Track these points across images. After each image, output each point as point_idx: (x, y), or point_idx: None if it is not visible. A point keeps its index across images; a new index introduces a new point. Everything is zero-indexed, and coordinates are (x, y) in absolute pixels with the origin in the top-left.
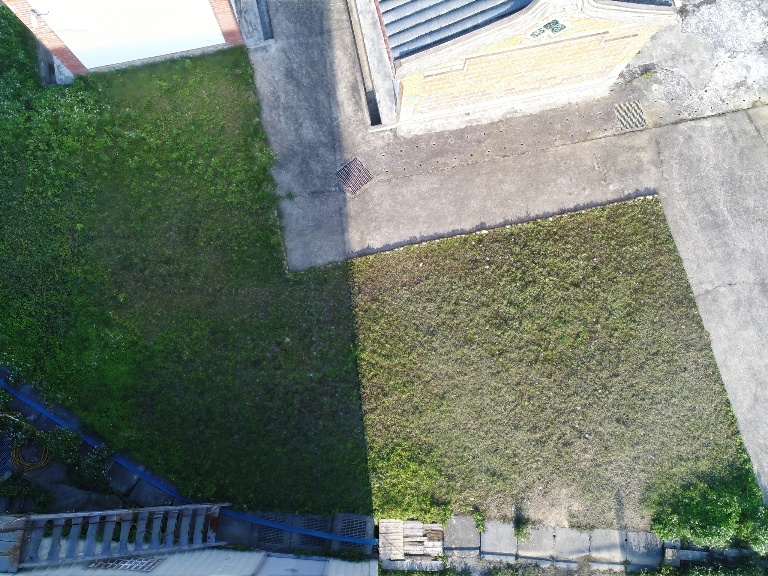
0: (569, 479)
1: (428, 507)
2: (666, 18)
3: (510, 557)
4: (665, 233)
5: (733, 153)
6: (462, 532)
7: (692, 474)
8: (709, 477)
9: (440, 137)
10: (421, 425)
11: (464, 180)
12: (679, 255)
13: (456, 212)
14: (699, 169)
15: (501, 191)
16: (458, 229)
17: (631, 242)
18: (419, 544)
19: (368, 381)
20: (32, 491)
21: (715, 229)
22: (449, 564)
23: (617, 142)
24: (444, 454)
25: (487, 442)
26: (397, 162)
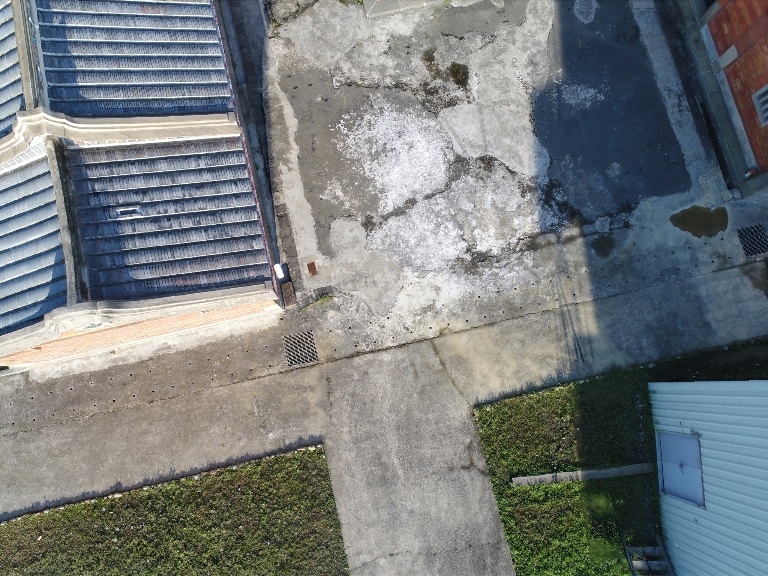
0: None
1: None
2: (258, 296)
3: None
4: (326, 491)
5: (413, 391)
6: None
7: None
8: None
9: (79, 380)
10: None
11: (102, 432)
12: (338, 519)
13: (89, 471)
14: (373, 412)
15: (143, 444)
16: (89, 492)
17: (285, 504)
18: None
19: None
20: None
21: (382, 485)
22: None
23: (282, 381)
24: None
25: None
26: (26, 412)
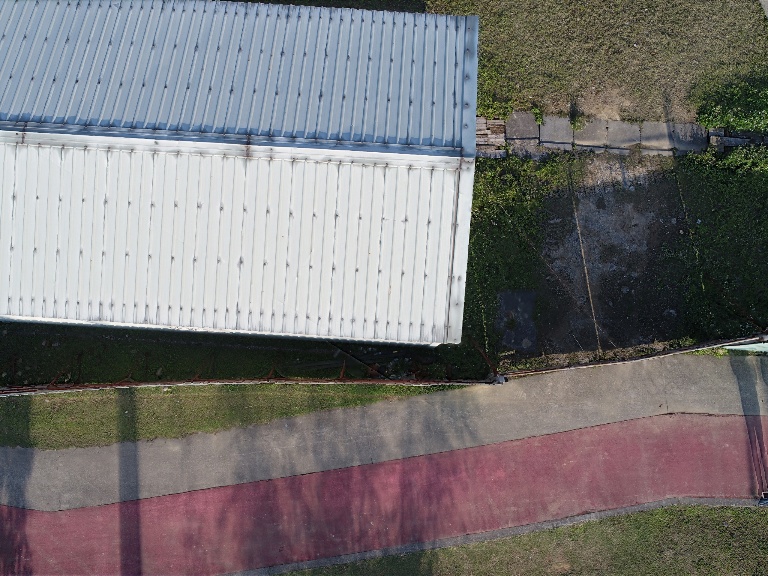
0: (619, 81)
1: (491, 103)
2: None
3: (567, 145)
4: None
5: None
6: (522, 125)
7: (733, 76)
8: (749, 79)
9: None
10: (482, 37)
11: None
12: None
13: None
14: None
15: None
16: None
17: None
18: (483, 136)
19: (432, 3)
20: None
21: None
22: (511, 151)
23: None
24: (504, 61)
25: (543, 51)
26: None
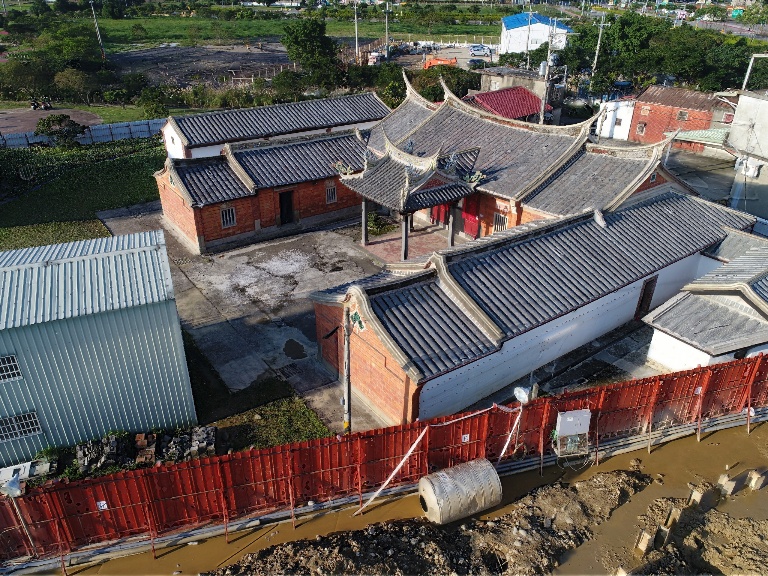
0: None
1: None
2: (189, 202)
3: None
4: None
5: None
6: None
7: None
8: None
9: None
10: None
11: None
12: None
13: None
14: None
15: None
16: None
17: None
18: None
19: None
20: (8, 189)
21: None
22: None
23: None
24: (3, 240)
25: None
26: None
